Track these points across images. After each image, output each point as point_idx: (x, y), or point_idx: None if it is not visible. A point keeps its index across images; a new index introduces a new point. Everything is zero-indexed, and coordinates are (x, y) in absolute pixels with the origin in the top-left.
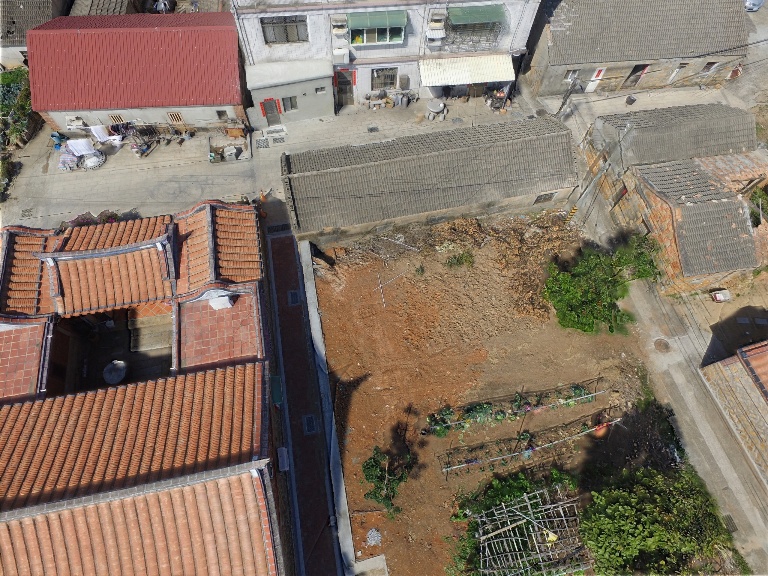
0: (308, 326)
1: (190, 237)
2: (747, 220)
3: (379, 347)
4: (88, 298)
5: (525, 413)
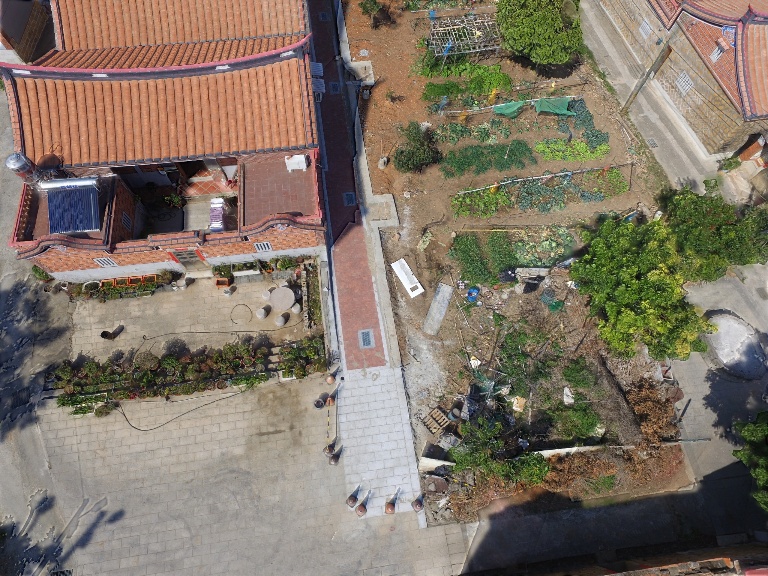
0: None
1: None
2: None
3: None
4: None
5: (472, 5)
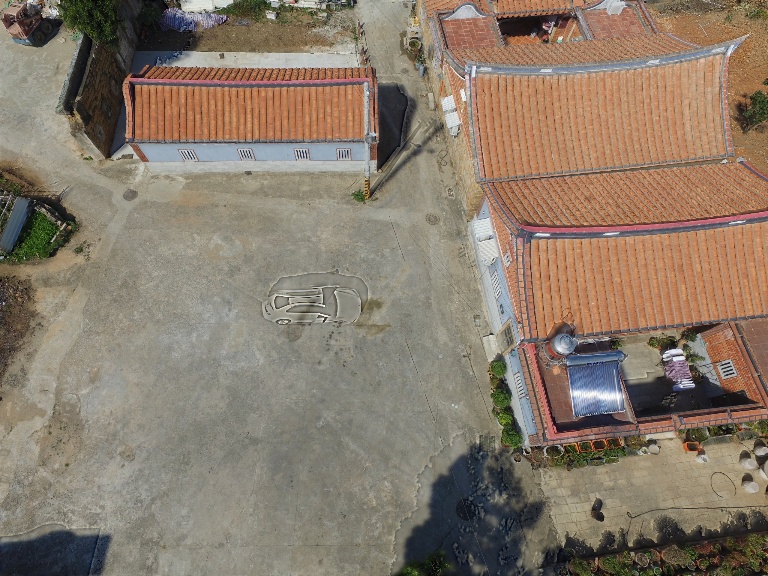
0: None
1: None
2: None
3: None
4: (513, 5)
5: None
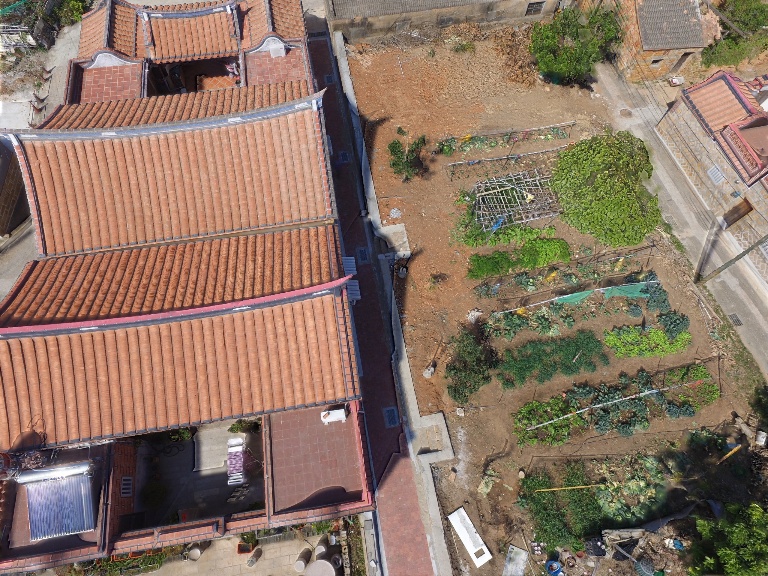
0: (341, 97)
1: (250, 11)
2: (696, 8)
3: (399, 101)
4: (173, 49)
5: (513, 143)
